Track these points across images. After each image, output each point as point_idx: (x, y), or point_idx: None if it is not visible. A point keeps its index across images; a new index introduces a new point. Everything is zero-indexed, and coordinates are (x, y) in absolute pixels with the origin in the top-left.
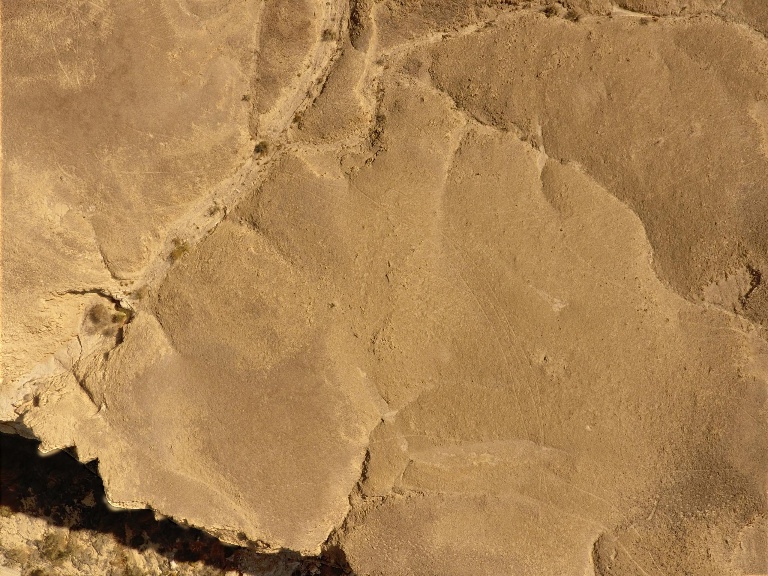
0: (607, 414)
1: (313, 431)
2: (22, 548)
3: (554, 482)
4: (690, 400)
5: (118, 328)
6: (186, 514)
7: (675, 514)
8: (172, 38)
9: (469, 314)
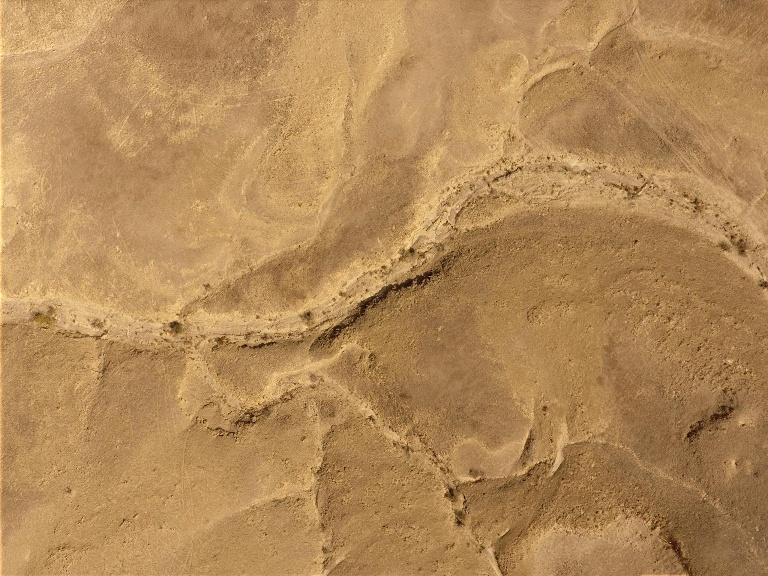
0: None
1: None
2: None
3: None
4: None
5: None
6: None
7: None
8: (212, 194)
9: None
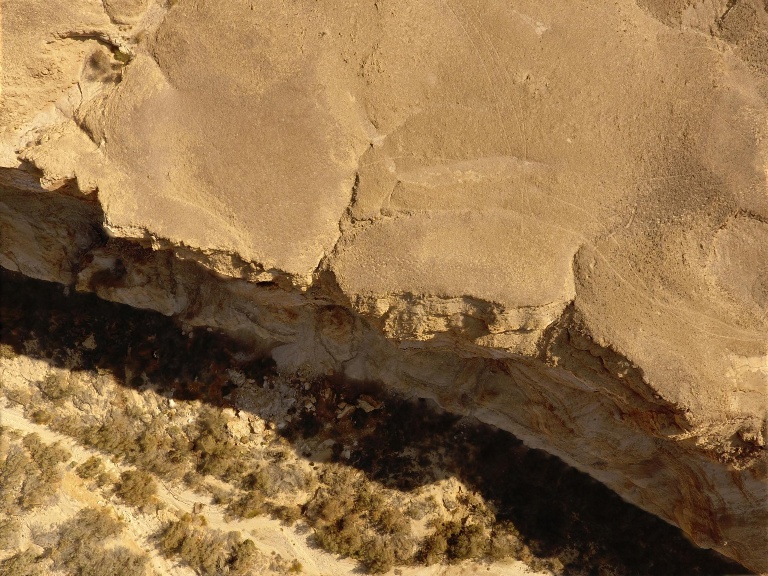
0: (587, 126)
1: (304, 152)
2: (24, 389)
3: (536, 195)
4: (667, 109)
5: None
6: (182, 236)
7: (652, 221)
8: None
9: (455, 39)
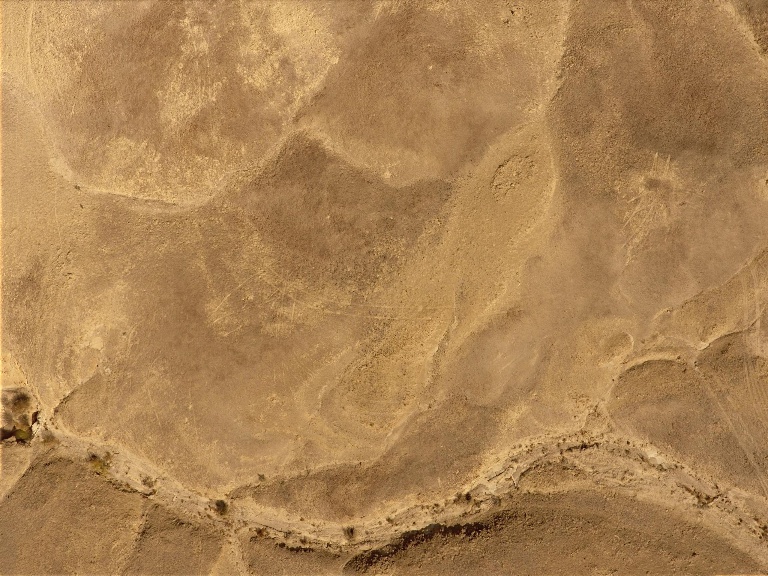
0: None
1: None
2: None
3: None
4: None
5: (14, 427)
6: None
7: None
8: (290, 391)
9: None
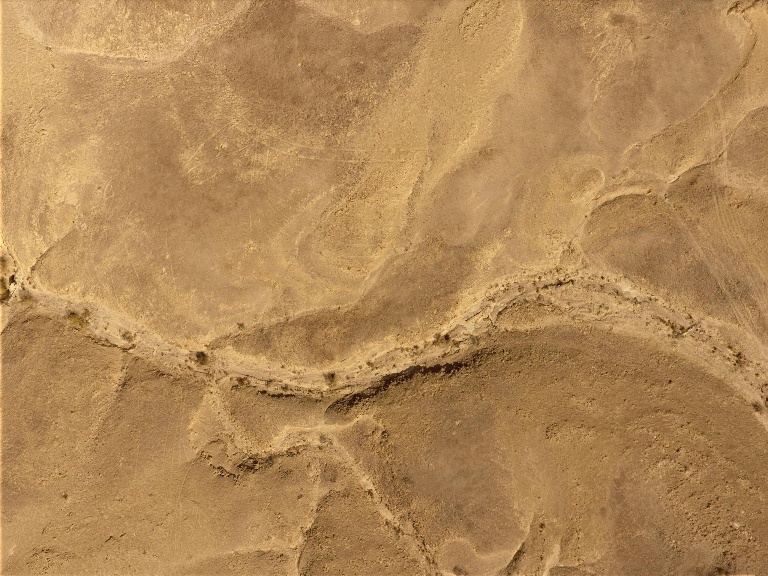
0: None
1: None
2: None
3: None
4: None
5: None
6: None
7: None
8: (267, 238)
9: None
